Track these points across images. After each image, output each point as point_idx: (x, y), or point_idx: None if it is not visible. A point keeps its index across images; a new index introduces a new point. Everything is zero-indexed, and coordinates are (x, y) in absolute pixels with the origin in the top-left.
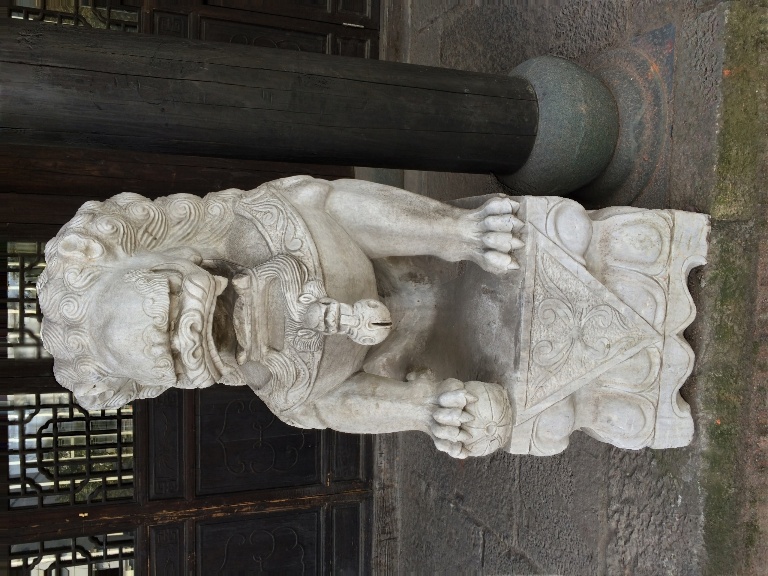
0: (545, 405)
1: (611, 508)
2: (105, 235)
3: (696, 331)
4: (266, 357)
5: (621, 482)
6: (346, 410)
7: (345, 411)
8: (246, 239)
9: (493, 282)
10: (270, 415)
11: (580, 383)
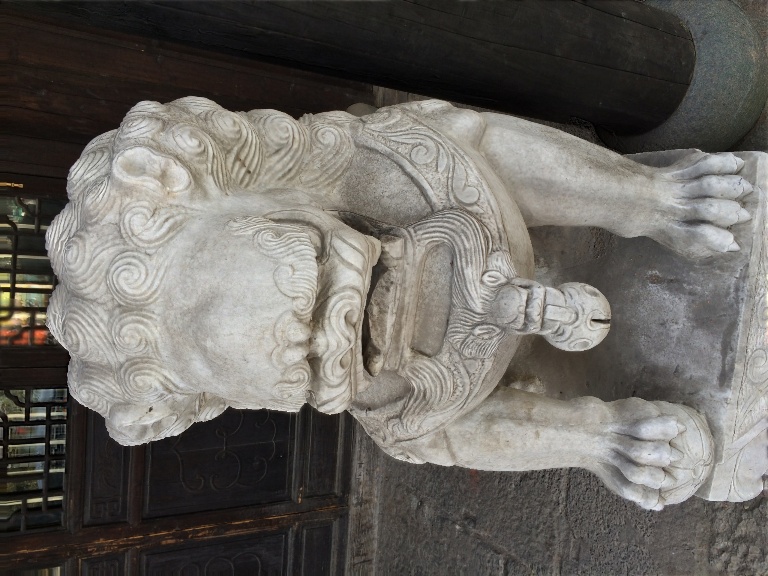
0: (752, 435)
1: (717, 546)
2: (189, 155)
3: None
4: (411, 365)
5: (734, 516)
6: (491, 440)
7: (490, 442)
8: (381, 184)
9: (677, 268)
10: (237, 419)
11: None
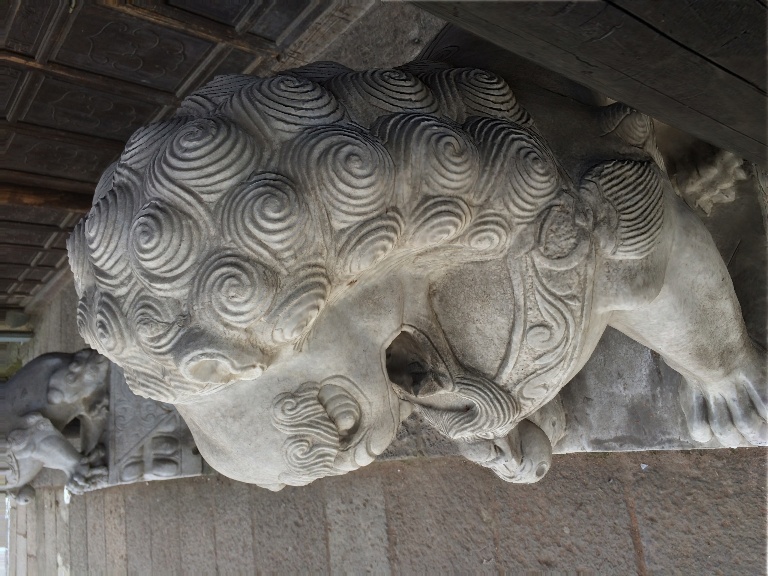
0: None
1: None
2: (279, 344)
3: None
4: None
5: None
6: None
7: None
8: (484, 314)
9: (671, 378)
10: None
11: None
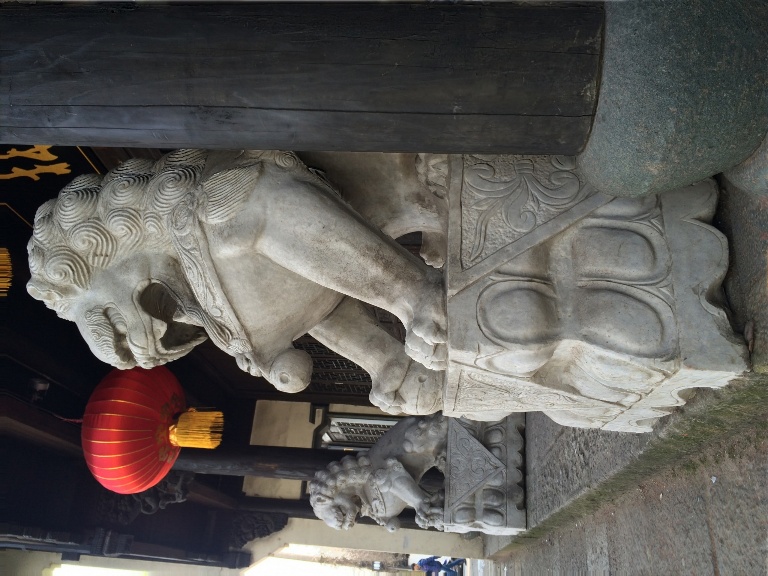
0: None
1: None
2: (57, 281)
3: None
4: None
5: None
6: None
7: None
8: None
9: None
10: None
11: None
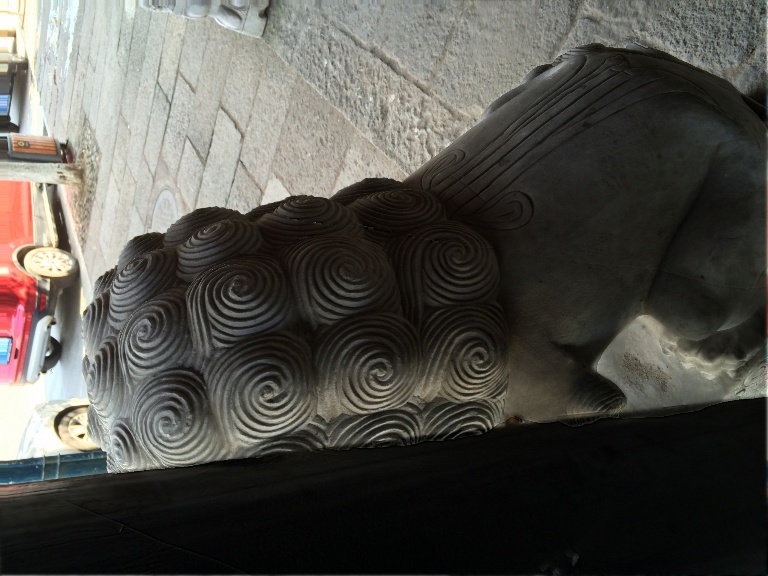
0: None
1: None
2: None
3: None
4: None
5: None
6: None
7: None
8: None
9: None
10: None
11: None
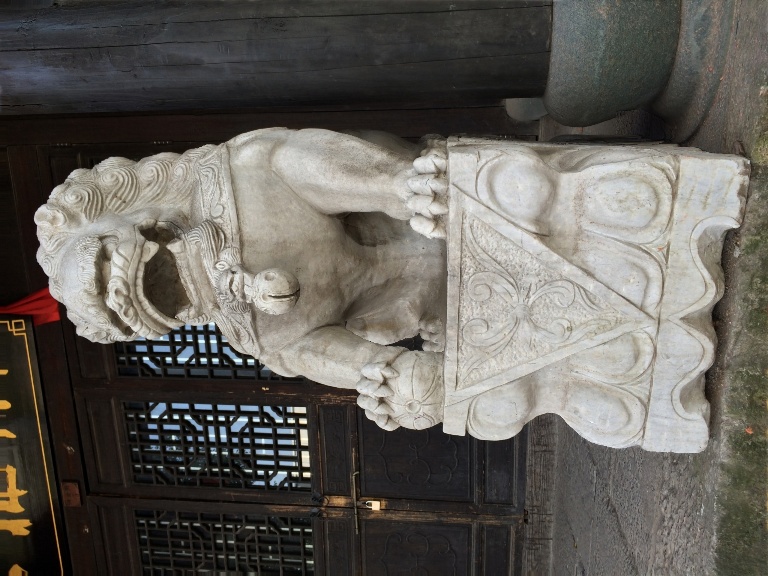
0: (481, 388)
1: (662, 492)
2: (70, 205)
3: (728, 313)
4: (211, 313)
5: (671, 467)
6: (302, 364)
7: (301, 365)
8: (195, 201)
9: None
10: None
11: (529, 368)
